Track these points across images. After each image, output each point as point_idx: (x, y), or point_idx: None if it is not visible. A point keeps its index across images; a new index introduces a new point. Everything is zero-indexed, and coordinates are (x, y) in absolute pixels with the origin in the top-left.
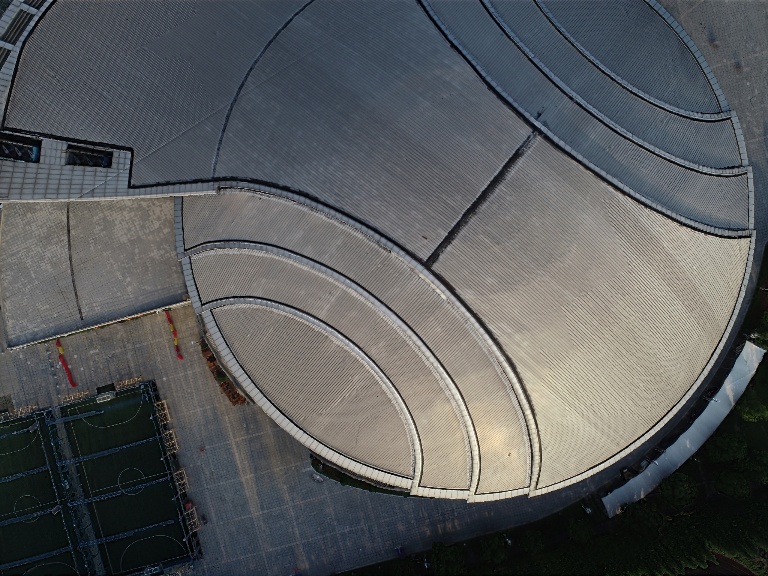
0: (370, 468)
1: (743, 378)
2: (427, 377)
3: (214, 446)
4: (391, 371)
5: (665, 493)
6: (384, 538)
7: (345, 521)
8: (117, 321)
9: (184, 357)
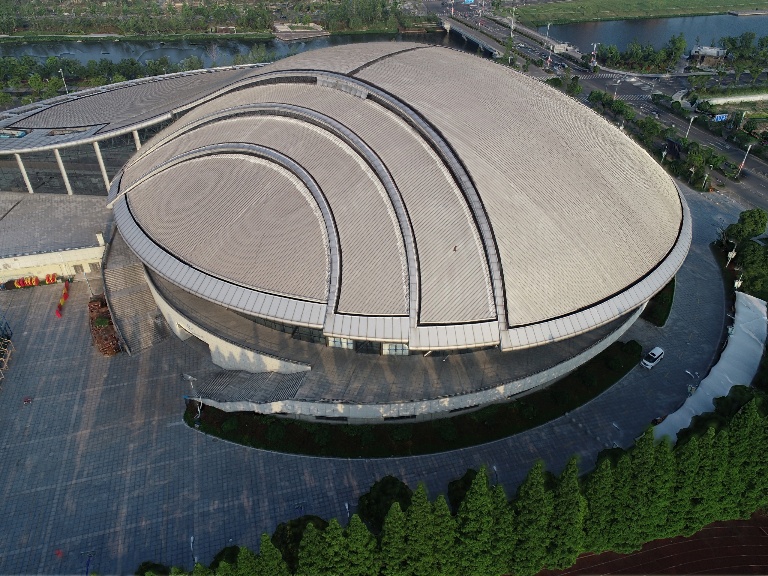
0: (269, 296)
1: (755, 320)
2: (347, 162)
3: (48, 398)
4: (308, 162)
5: (722, 406)
6: (277, 520)
7: (214, 493)
8: (5, 285)
9: (63, 316)
